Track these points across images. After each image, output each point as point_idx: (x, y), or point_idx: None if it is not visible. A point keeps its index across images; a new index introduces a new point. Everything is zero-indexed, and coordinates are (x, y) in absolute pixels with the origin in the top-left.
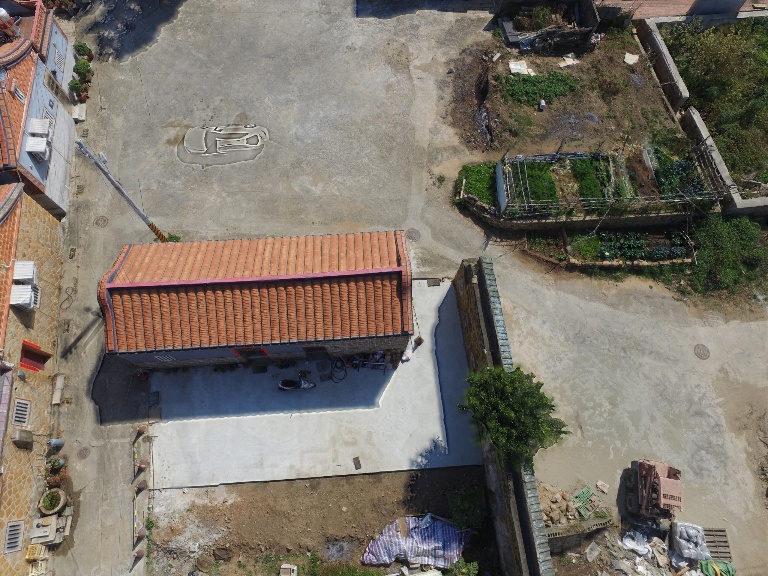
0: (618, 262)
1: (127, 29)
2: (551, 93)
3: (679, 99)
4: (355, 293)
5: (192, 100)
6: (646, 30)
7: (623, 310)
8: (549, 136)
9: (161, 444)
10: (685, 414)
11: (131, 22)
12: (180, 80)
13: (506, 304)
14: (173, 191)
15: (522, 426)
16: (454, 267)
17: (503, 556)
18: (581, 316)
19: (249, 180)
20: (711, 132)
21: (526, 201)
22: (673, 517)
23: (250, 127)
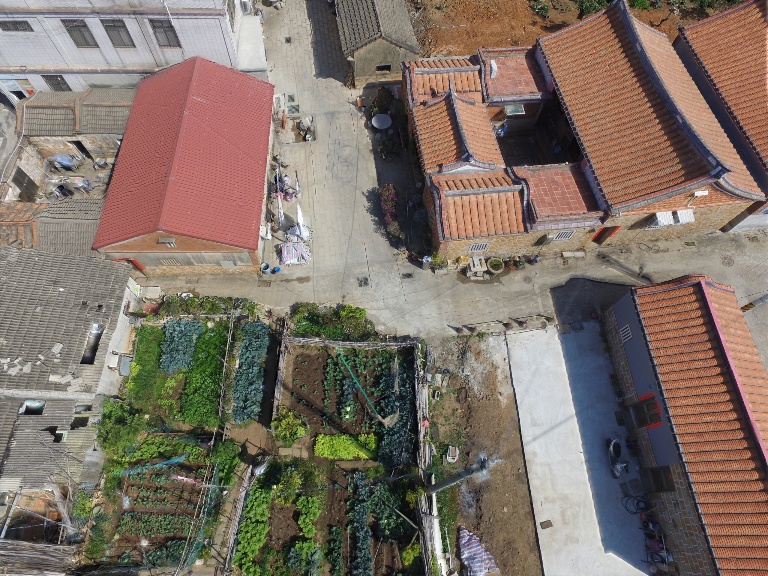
0: None
1: None
2: None
3: None
4: (766, 533)
5: None
6: None
7: None
8: None
9: (541, 336)
10: None
11: None
12: None
13: None
14: None
15: None
16: None
17: None
18: None
19: None
20: None
21: None
22: None
23: None
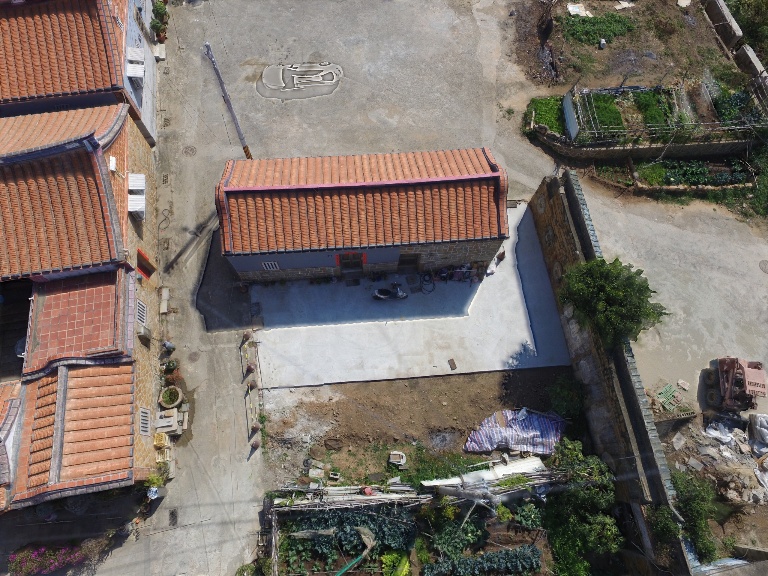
0: (684, 186)
1: None
2: (610, 33)
3: (732, 38)
4: (455, 198)
5: (266, 40)
6: None
7: (690, 230)
8: (611, 72)
9: (266, 349)
10: (755, 321)
11: None
12: (253, 22)
13: None
14: (256, 123)
15: (629, 305)
16: (528, 191)
17: (600, 440)
18: (651, 235)
19: (328, 113)
20: None
21: (595, 129)
22: (756, 405)
23: (324, 65)
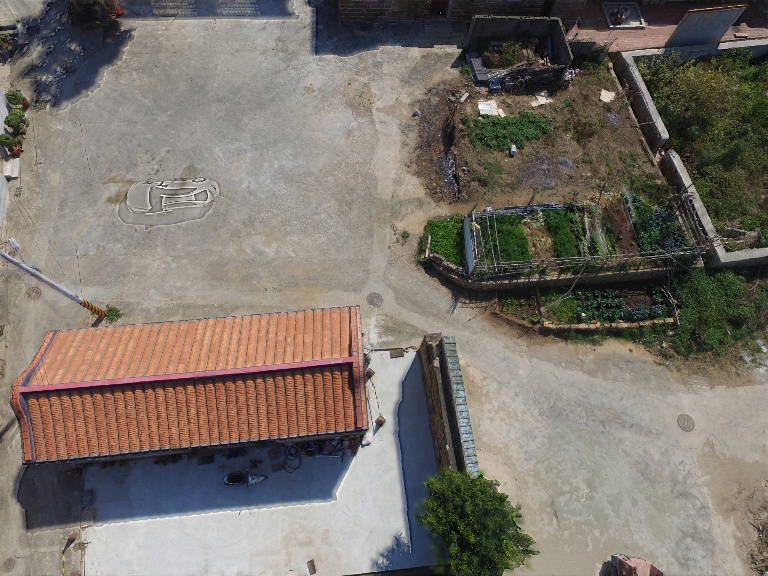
0: (595, 324)
1: (67, 73)
2: (522, 137)
3: (658, 140)
4: (302, 386)
5: (136, 152)
6: (623, 64)
7: (601, 378)
8: (521, 185)
9: (94, 552)
10: (669, 495)
11: (71, 65)
12: (123, 129)
13: (476, 375)
14: (113, 256)
15: (483, 551)
16: (419, 335)
17: None
18: (556, 386)
19: (197, 242)
20: (693, 175)
21: (496, 260)
22: None
23: (199, 181)
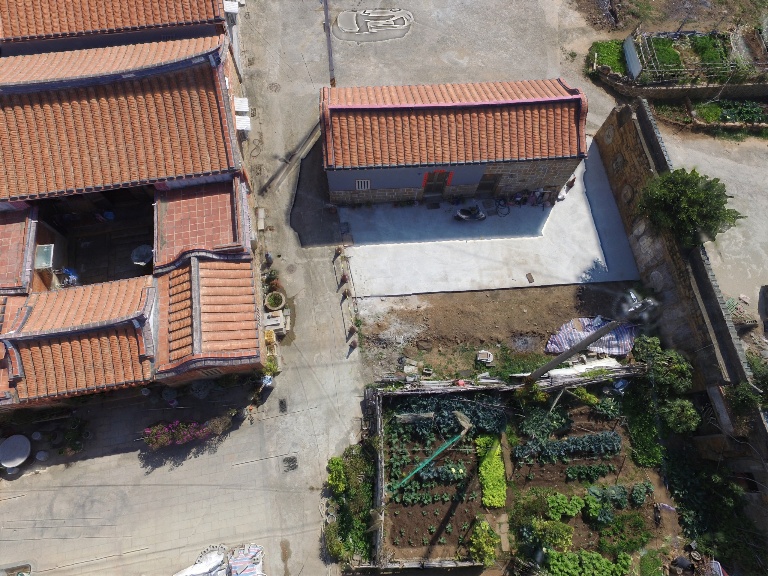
0: (740, 123)
1: None
2: None
3: None
4: (538, 119)
5: None
6: None
7: (746, 164)
8: (668, 18)
9: (356, 263)
10: None
11: None
12: None
13: None
14: (335, 63)
15: (709, 206)
16: (593, 127)
17: (673, 341)
18: (709, 168)
19: (402, 54)
20: None
21: None
22: None
23: (395, 11)
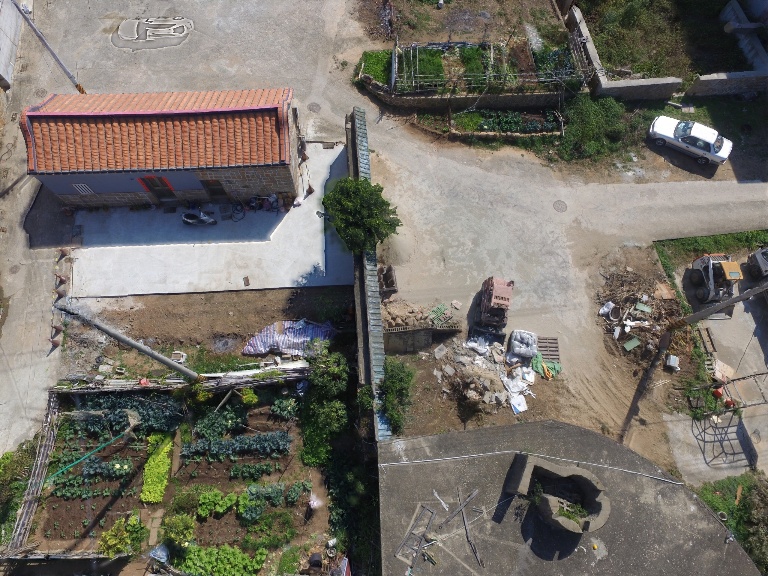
0: (494, 133)
1: None
2: None
3: (566, 1)
4: (240, 128)
5: None
6: None
7: (495, 173)
8: (444, 29)
9: (81, 264)
10: (537, 253)
11: None
12: None
13: (392, 166)
14: (105, 69)
15: (358, 214)
16: None
17: None
18: (457, 176)
19: (173, 61)
20: (595, 31)
21: None
22: (505, 318)
23: (178, 19)
